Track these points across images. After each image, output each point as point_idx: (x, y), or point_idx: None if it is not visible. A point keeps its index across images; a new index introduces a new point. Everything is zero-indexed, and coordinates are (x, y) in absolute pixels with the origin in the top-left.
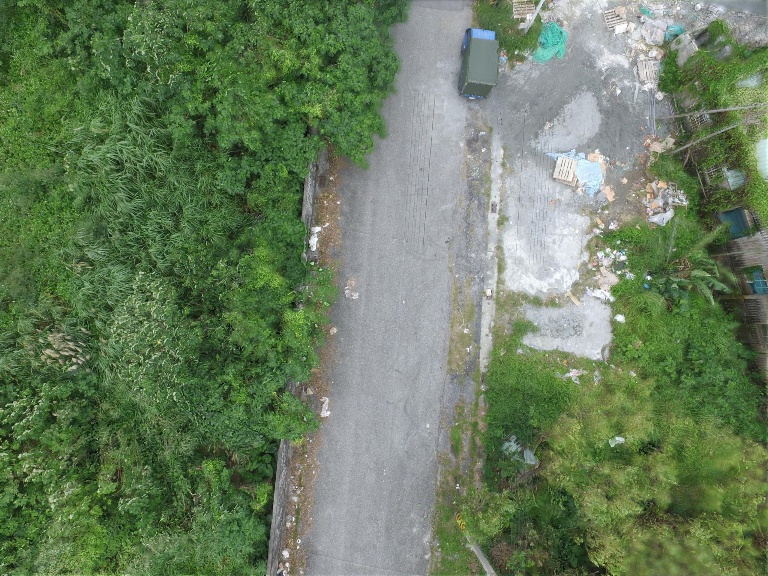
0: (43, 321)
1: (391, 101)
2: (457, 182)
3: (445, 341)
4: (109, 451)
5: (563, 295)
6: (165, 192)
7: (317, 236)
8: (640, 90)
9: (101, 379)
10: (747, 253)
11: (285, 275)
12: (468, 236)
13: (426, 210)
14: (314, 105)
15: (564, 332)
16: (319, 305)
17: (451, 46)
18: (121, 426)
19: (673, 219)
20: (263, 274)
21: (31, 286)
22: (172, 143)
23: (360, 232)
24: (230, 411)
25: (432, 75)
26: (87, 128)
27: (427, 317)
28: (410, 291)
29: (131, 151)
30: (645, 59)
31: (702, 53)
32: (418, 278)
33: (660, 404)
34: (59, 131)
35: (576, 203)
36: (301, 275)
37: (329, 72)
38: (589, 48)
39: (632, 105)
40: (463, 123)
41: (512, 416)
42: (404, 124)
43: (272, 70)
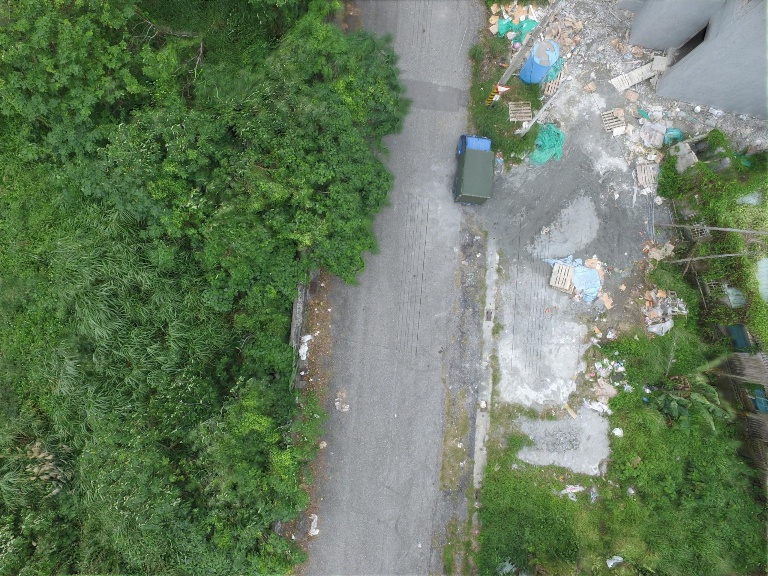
0: (24, 438)
1: (384, 205)
2: (451, 289)
3: (438, 456)
4: (90, 575)
5: (559, 407)
6: (151, 307)
7: (307, 345)
8: (639, 194)
9: (82, 502)
10: (748, 369)
11: (271, 409)
12: (462, 345)
13: (419, 318)
14: (303, 233)
15: (560, 446)
16: (309, 417)
17: (446, 148)
18: (103, 548)
19: (672, 330)
20: (248, 416)
21: (12, 399)
22: (159, 255)
23: (351, 341)
24: (213, 556)
25: (426, 178)
26: (72, 238)
27: (420, 431)
28: (402, 403)
29: (116, 263)
30: (644, 163)
31: (702, 165)
32: (411, 390)
33: (659, 525)
34: (43, 239)
35: (573, 311)
36: (288, 407)
37: (318, 201)
38: (587, 150)
39: (630, 209)
40: (458, 228)
41: (506, 538)
42: (397, 229)
43: (260, 198)
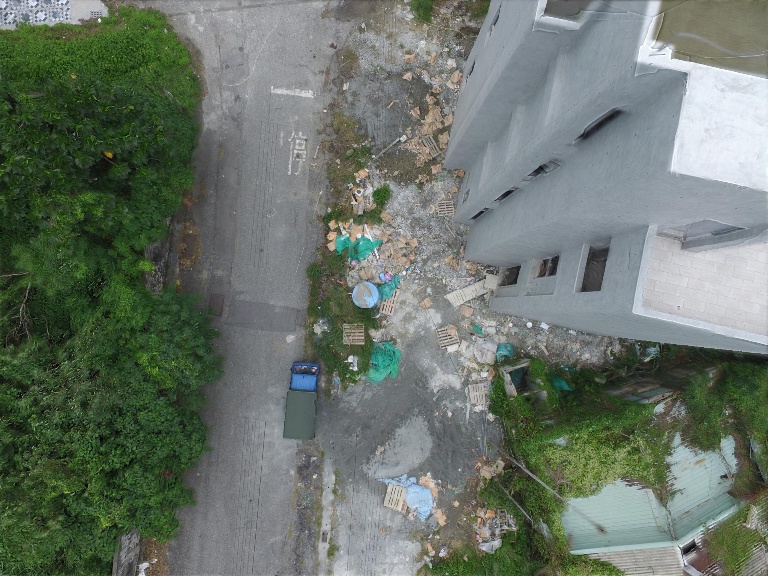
0: None
1: (221, 429)
2: (287, 512)
3: None
4: None
5: None
6: None
7: (145, 574)
8: (472, 411)
9: None
10: None
11: None
12: (298, 568)
13: (255, 544)
14: (104, 516)
15: None
16: None
17: (282, 370)
18: None
19: (500, 550)
20: None
21: None
22: None
23: (188, 569)
24: None
25: (263, 401)
26: None
27: None
28: None
29: None
30: (476, 380)
31: (520, 400)
32: None
33: None
34: None
35: (407, 529)
36: None
37: (116, 487)
38: (422, 367)
39: (464, 425)
40: (294, 449)
41: None
42: (234, 454)
43: None
